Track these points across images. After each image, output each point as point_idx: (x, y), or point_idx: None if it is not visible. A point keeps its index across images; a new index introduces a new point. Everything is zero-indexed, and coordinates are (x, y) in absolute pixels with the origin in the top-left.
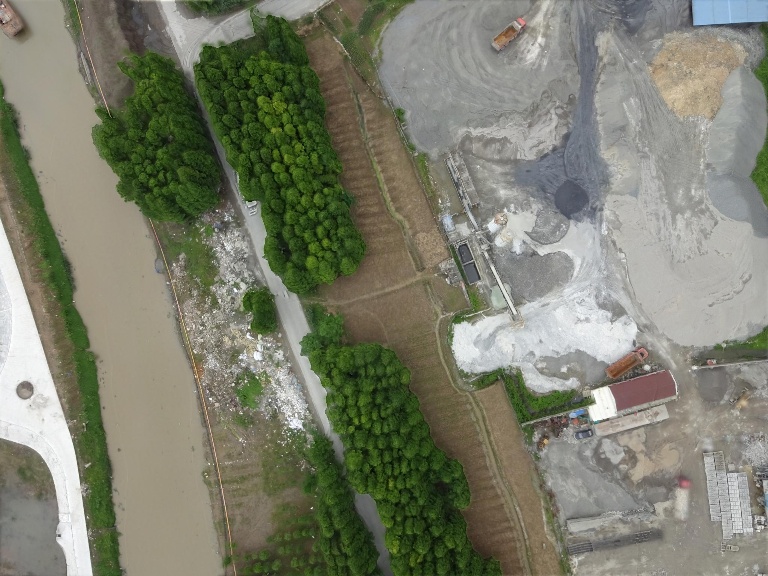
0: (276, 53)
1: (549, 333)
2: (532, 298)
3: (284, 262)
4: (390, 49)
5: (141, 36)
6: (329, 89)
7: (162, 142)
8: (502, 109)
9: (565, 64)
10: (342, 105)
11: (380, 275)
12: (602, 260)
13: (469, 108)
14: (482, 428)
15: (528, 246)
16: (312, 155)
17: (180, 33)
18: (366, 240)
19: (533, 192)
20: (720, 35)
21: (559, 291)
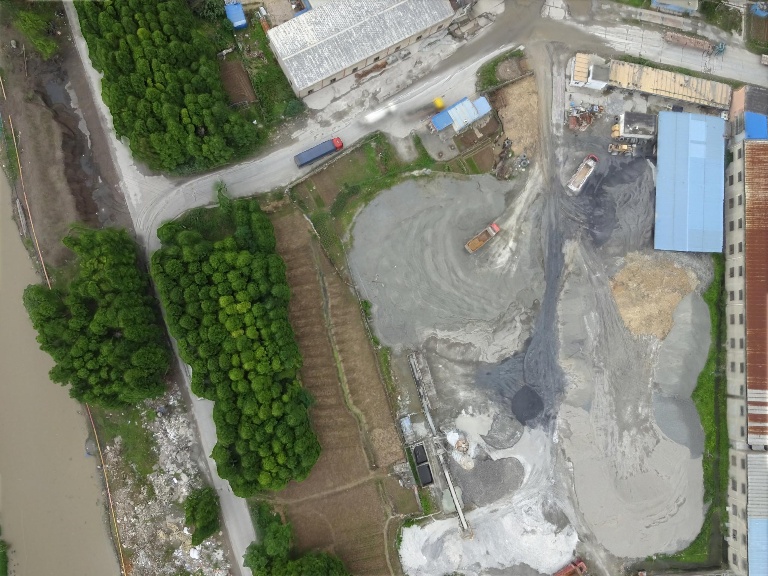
0: (243, 240)
1: (496, 544)
2: (482, 504)
3: (234, 474)
4: (362, 238)
5: (90, 188)
6: (294, 268)
7: (107, 331)
8: (470, 317)
9: (533, 273)
10: (307, 287)
11: (332, 473)
12: (551, 468)
13: (438, 313)
14: None
15: (482, 450)
16: (274, 361)
17: (135, 190)
18: (320, 433)
19: (491, 395)
20: (677, 261)
21: (508, 498)
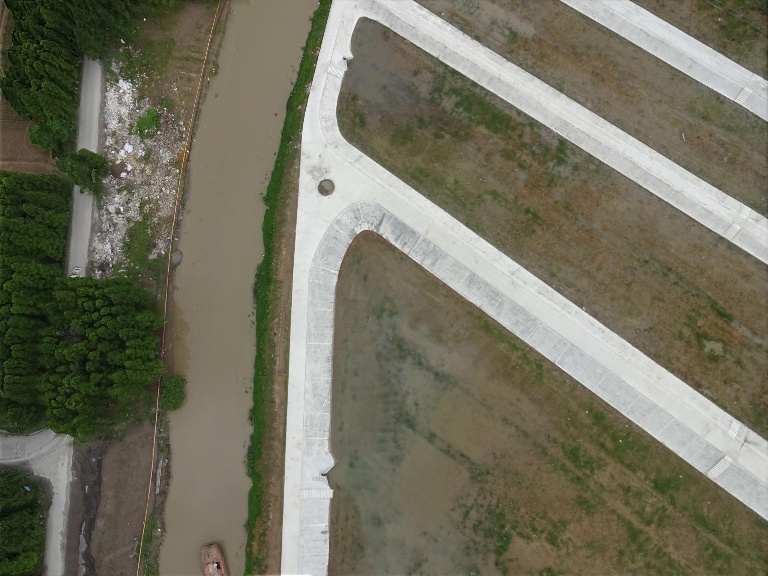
0: None
1: None
2: None
3: None
4: None
5: (97, 484)
6: None
7: None
8: None
9: None
10: None
11: None
12: None
13: None
14: (0, 38)
15: None
16: None
17: (62, 468)
18: None
19: None
20: None
21: None
